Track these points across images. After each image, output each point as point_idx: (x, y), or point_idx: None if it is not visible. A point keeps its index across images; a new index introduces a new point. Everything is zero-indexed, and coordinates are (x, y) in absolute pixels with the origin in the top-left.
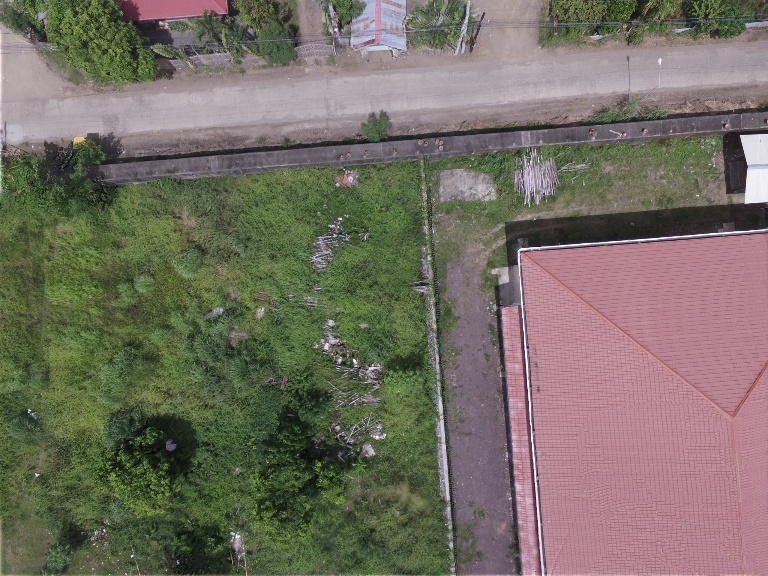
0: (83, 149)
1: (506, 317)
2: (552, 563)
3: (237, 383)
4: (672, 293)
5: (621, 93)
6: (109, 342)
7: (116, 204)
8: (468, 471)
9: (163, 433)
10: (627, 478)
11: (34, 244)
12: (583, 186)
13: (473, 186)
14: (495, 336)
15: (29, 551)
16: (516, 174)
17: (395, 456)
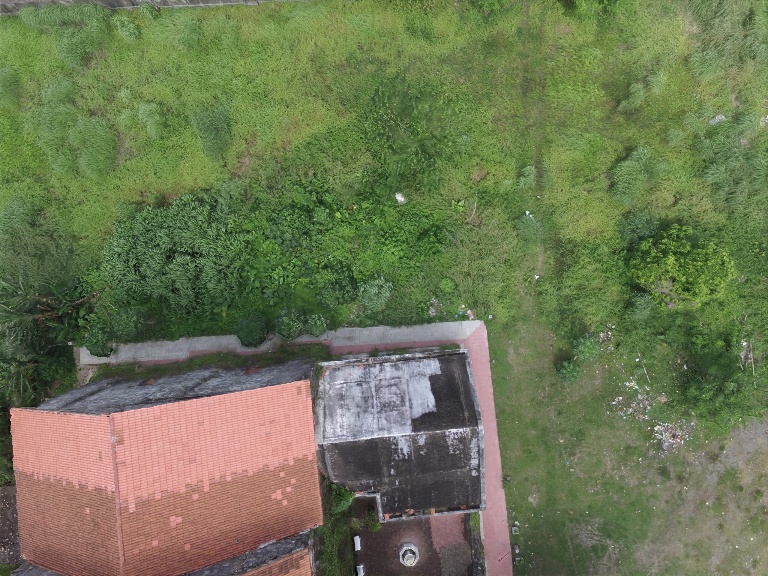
0: None
1: None
2: None
3: (760, 183)
4: None
5: None
6: (610, 145)
7: (621, 6)
8: None
9: None
10: None
11: (532, 46)
12: None
13: None
14: None
15: (532, 352)
16: None
17: None
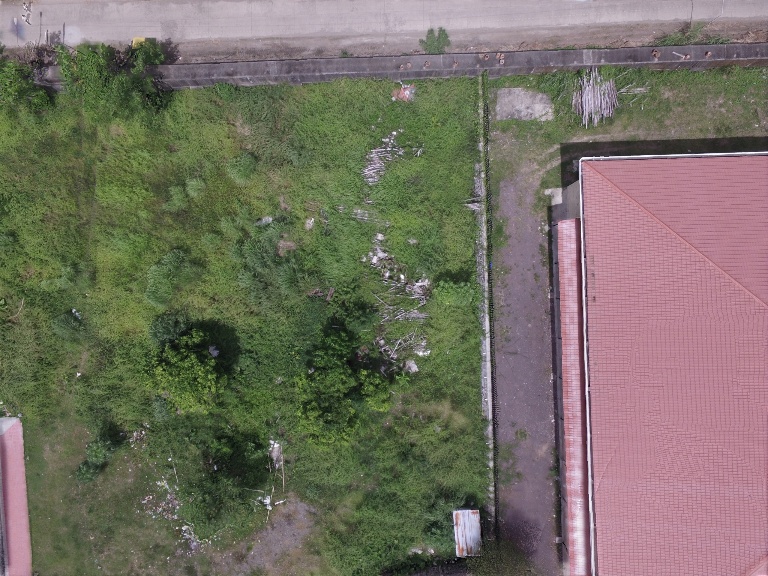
0: (143, 48)
1: (562, 230)
2: (600, 475)
3: (285, 289)
4: (736, 206)
5: (683, 20)
6: (157, 245)
7: (171, 108)
8: (512, 391)
9: (208, 335)
10: (677, 399)
11: (87, 145)
12: (641, 110)
13: (530, 105)
14: (545, 257)
15: (67, 449)
16: (574, 95)
17: (438, 373)
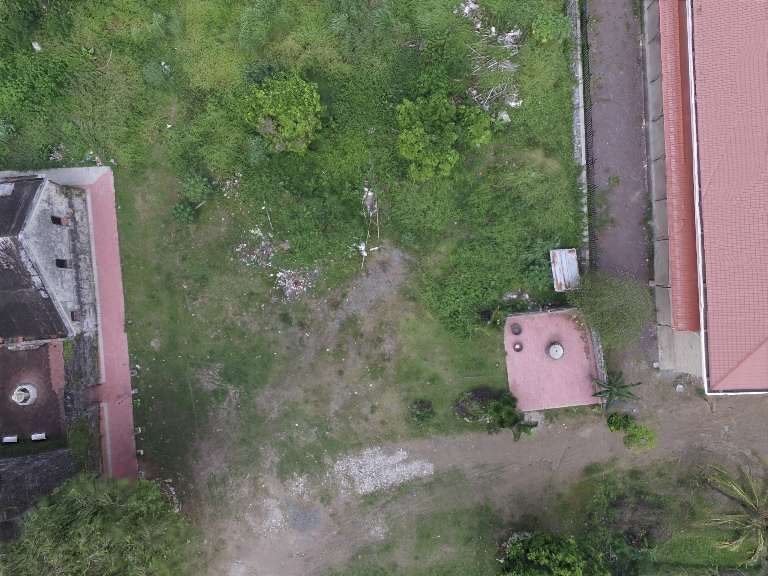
0: None
1: None
2: (707, 181)
3: (380, 32)
4: None
5: None
6: None
7: None
8: (604, 137)
9: None
10: None
11: None
12: None
13: None
14: (637, 5)
15: (159, 199)
16: None
17: (531, 122)
